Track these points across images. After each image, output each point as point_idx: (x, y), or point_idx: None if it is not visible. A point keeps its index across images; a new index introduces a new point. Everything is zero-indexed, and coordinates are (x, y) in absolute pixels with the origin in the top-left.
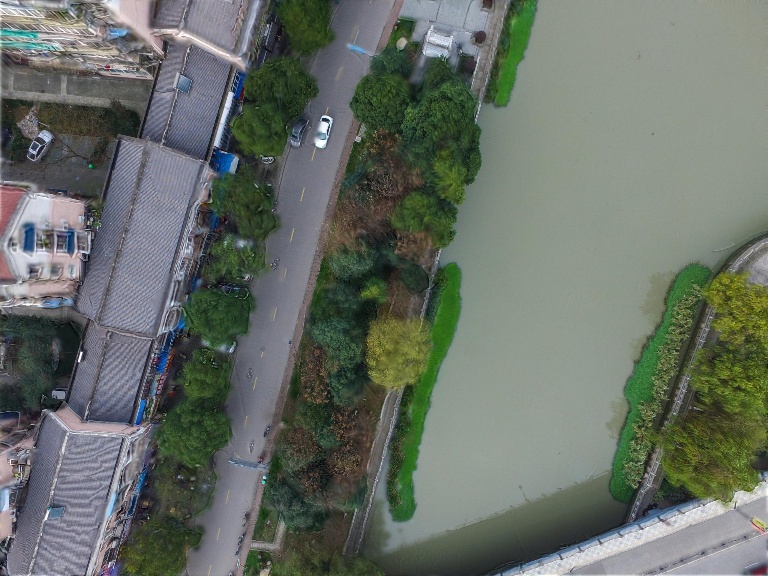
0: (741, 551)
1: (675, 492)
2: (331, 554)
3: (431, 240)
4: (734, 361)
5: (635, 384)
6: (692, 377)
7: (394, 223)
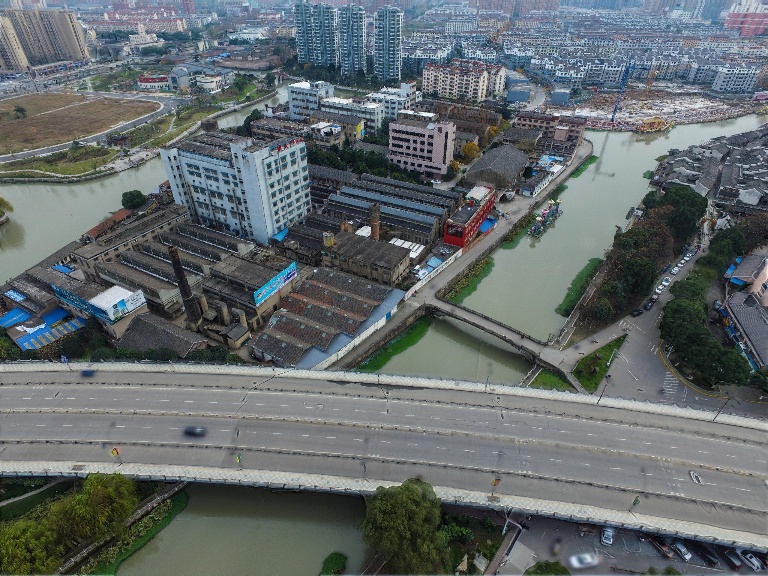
0: (144, 437)
1: (147, 487)
2: (391, 561)
3: None
4: (12, 573)
5: None
6: (56, 569)
7: None
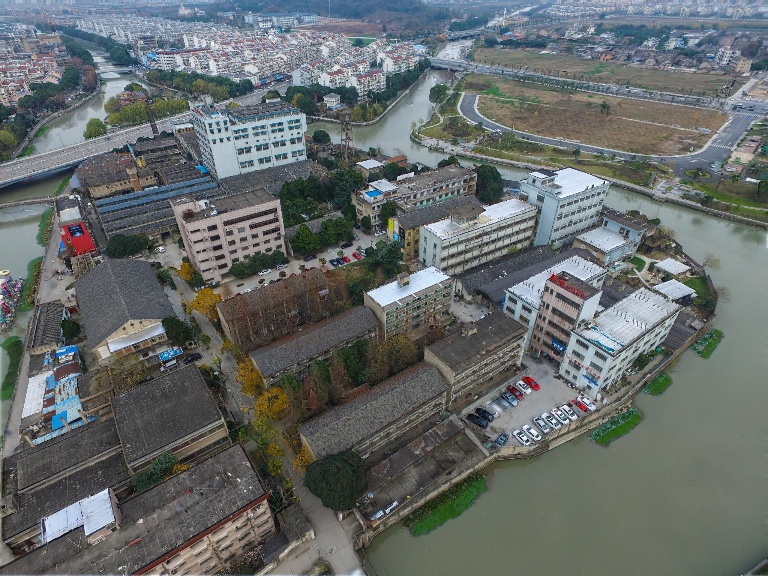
0: None
1: None
2: None
3: (14, 131)
4: None
5: None
6: None
7: (2, 126)
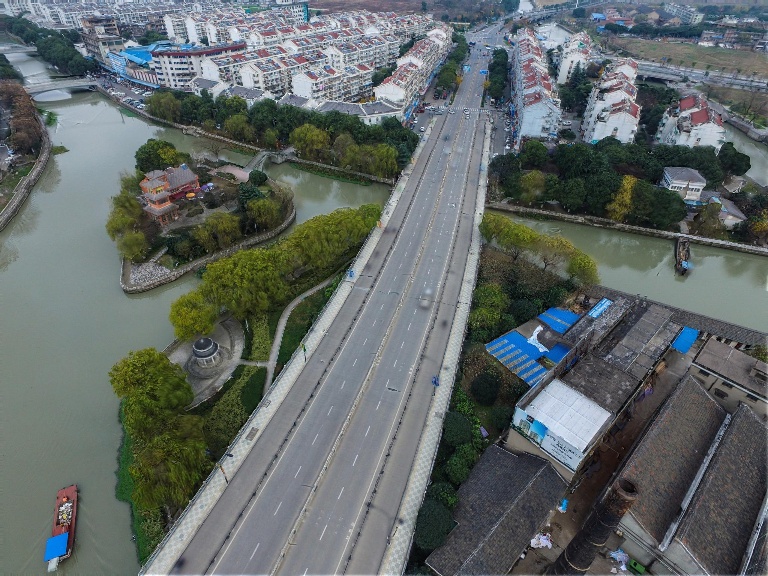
0: (261, 507)
1: None
2: None
3: None
4: None
5: (124, 484)
6: None
7: None
